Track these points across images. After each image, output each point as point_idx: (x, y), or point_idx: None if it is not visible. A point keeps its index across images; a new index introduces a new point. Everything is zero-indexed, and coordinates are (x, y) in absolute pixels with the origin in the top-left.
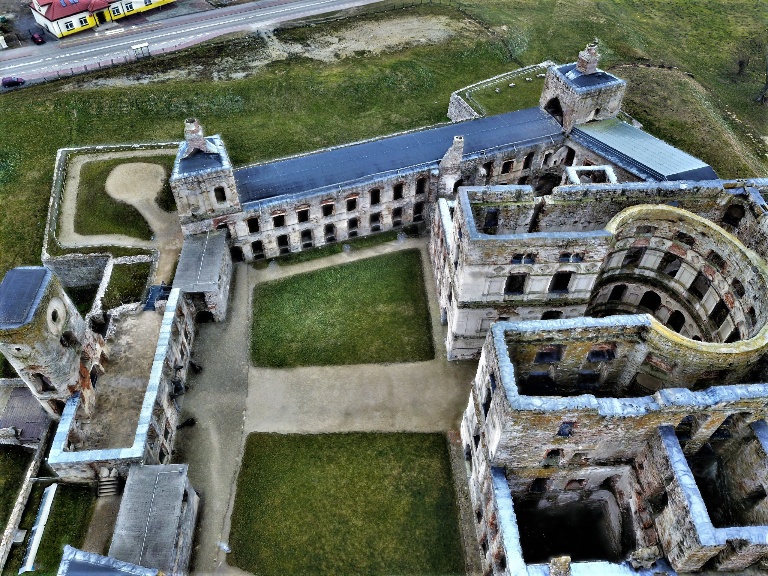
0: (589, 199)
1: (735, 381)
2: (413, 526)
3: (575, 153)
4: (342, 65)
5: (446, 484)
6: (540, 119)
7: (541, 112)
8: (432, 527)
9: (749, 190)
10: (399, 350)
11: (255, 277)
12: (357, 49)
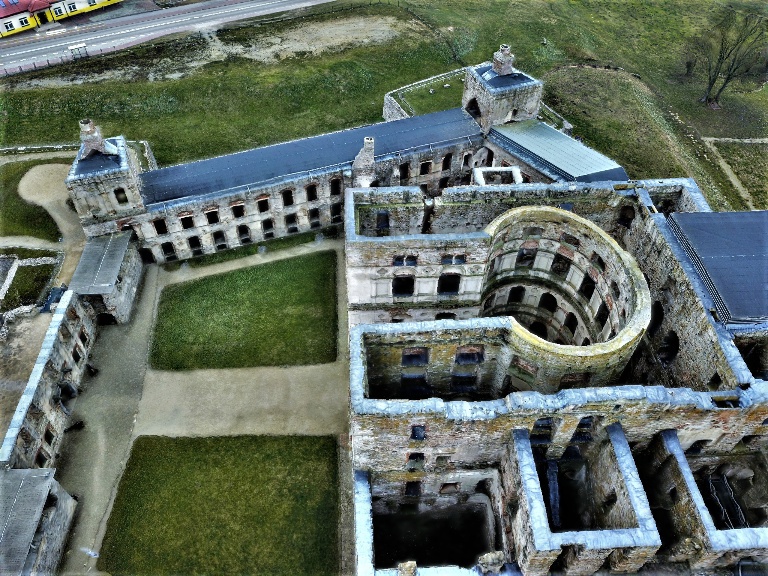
0: (478, 200)
1: (600, 384)
2: (291, 530)
3: (493, 154)
4: (281, 66)
5: (330, 487)
6: (460, 120)
7: (462, 113)
8: (310, 531)
9: (639, 191)
10: (301, 352)
11: (165, 279)
12: (298, 50)
